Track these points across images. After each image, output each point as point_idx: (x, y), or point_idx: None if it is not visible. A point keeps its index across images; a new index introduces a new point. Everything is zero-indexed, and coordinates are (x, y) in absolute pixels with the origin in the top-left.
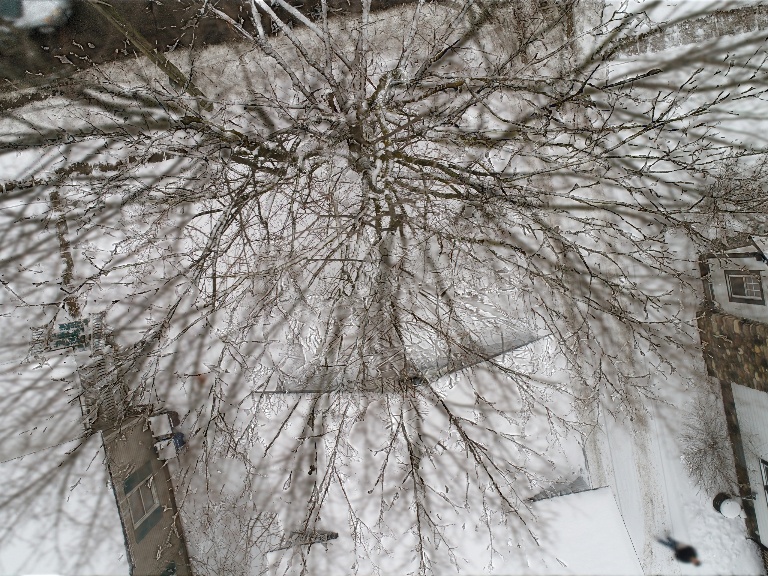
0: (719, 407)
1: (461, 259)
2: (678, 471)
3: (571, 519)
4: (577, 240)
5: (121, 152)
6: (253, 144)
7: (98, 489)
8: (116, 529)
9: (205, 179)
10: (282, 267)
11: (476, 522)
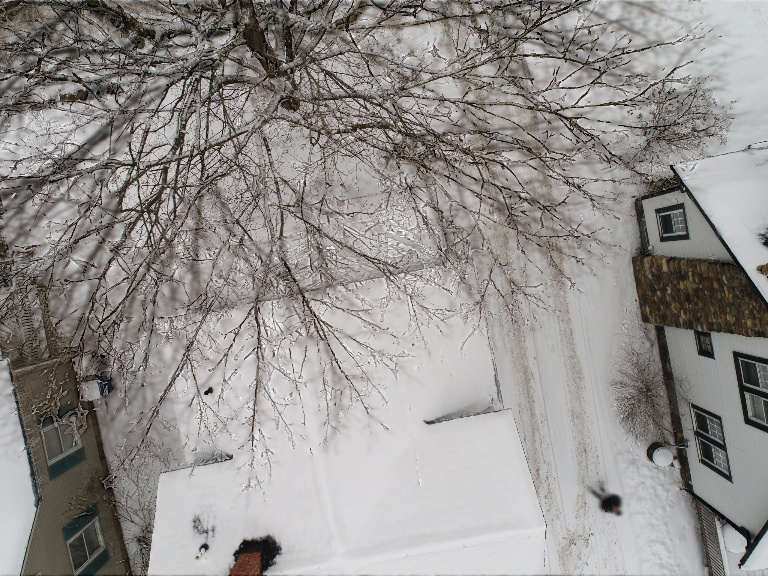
0: (655, 355)
1: (392, 200)
2: (612, 420)
3: (468, 439)
4: (512, 182)
5: (51, 90)
6: (163, 64)
7: (2, 417)
8: (21, 459)
9: (135, 117)
10: (156, 162)
11: (365, 438)
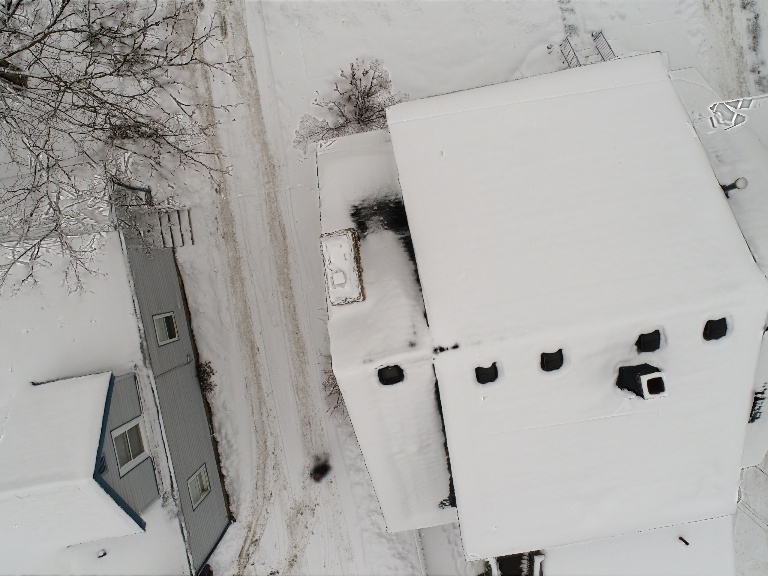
0: None
1: None
2: None
3: (58, 399)
4: (236, 162)
5: None
6: None
7: None
8: None
9: None
10: None
11: None
